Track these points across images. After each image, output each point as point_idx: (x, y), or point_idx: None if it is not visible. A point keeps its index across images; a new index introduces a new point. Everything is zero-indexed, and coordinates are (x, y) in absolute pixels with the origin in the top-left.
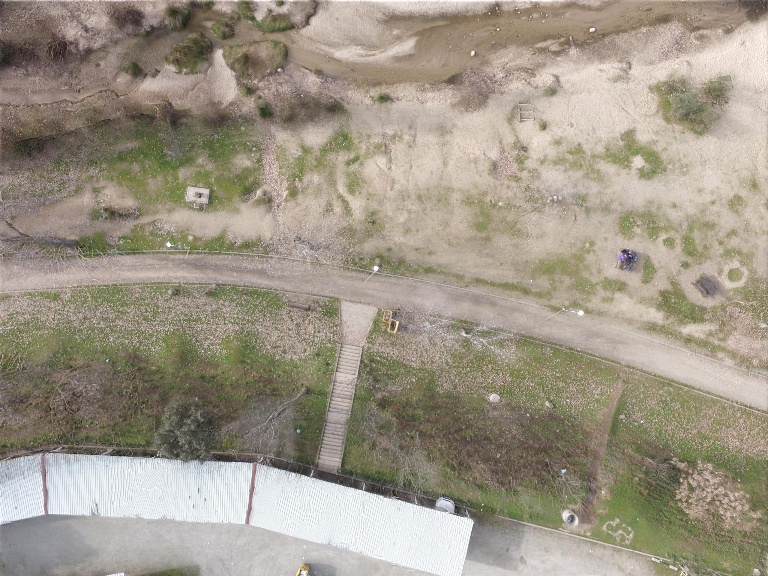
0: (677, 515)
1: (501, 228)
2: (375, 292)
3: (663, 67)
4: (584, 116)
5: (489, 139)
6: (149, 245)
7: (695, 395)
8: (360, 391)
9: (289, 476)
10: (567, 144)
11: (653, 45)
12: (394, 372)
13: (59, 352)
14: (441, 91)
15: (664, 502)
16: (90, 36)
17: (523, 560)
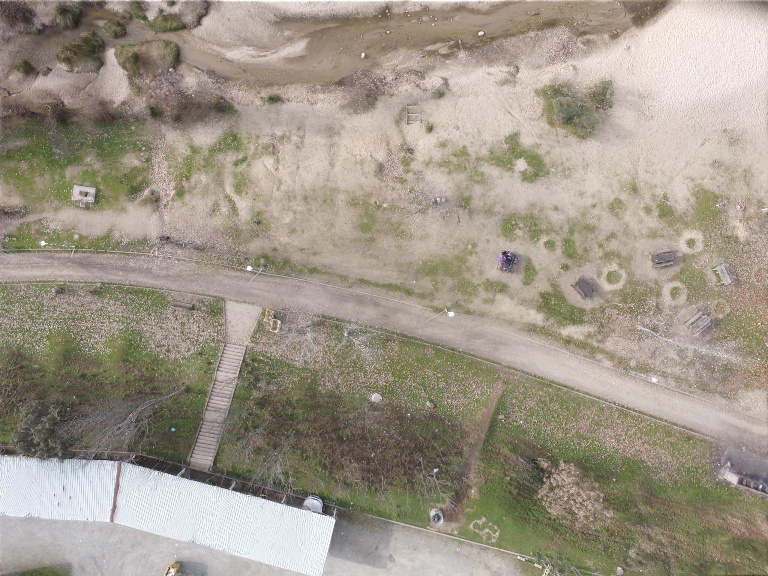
0: (545, 514)
1: (385, 229)
2: (260, 292)
3: (550, 71)
4: (470, 119)
5: (376, 141)
6: (35, 243)
7: (574, 396)
8: (240, 390)
9: (151, 474)
10: (452, 146)
11: (540, 49)
12: (277, 371)
13: None
14: (332, 93)
15: (534, 501)
16: None
17: (392, 558)
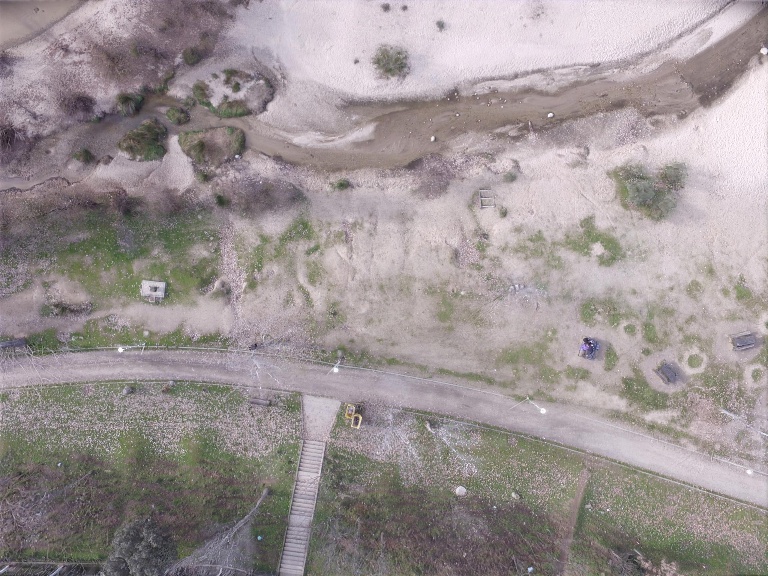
0: None
1: (464, 317)
2: (338, 385)
3: (620, 152)
4: (544, 202)
5: (450, 226)
6: (102, 342)
7: (659, 481)
8: (323, 490)
9: None
10: (528, 231)
11: (610, 130)
12: (358, 467)
13: (7, 457)
14: (402, 177)
15: None
16: (39, 123)
17: None
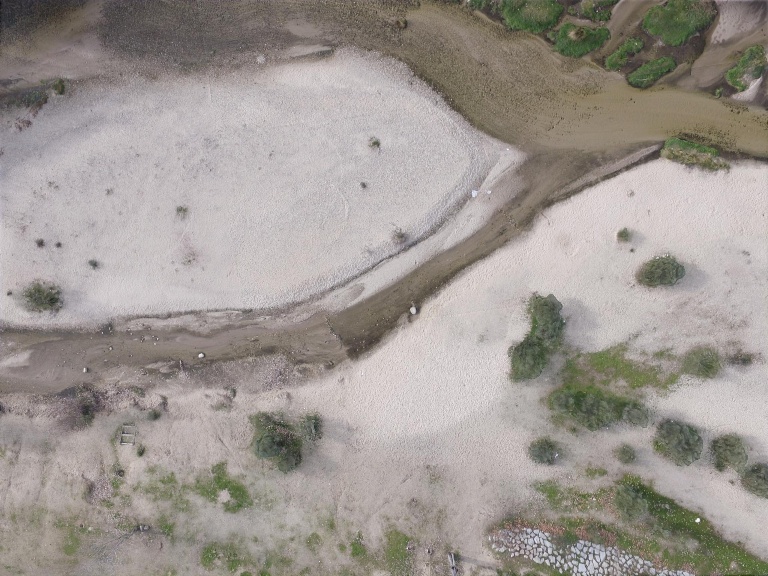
0: None
1: (89, 552)
2: None
3: (265, 397)
4: (182, 444)
5: (90, 459)
6: None
7: None
8: None
9: None
10: (161, 472)
11: (258, 375)
12: None
13: None
14: (53, 404)
15: None
16: None
17: None
